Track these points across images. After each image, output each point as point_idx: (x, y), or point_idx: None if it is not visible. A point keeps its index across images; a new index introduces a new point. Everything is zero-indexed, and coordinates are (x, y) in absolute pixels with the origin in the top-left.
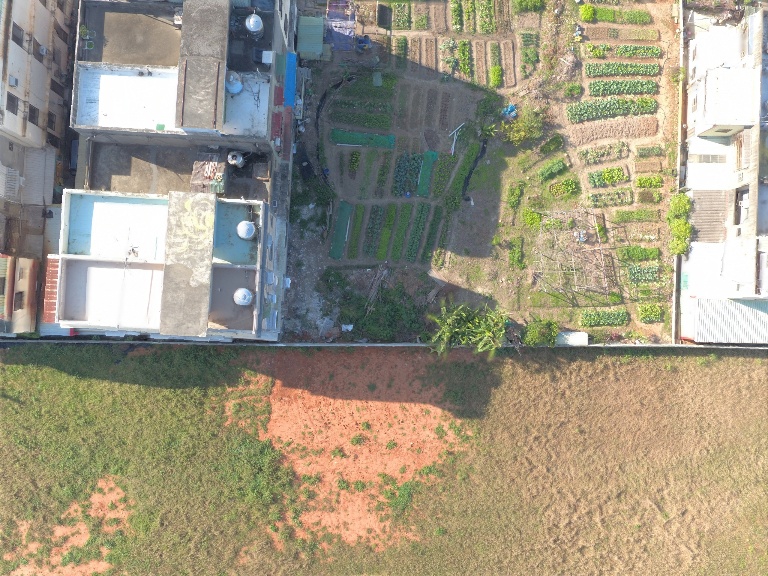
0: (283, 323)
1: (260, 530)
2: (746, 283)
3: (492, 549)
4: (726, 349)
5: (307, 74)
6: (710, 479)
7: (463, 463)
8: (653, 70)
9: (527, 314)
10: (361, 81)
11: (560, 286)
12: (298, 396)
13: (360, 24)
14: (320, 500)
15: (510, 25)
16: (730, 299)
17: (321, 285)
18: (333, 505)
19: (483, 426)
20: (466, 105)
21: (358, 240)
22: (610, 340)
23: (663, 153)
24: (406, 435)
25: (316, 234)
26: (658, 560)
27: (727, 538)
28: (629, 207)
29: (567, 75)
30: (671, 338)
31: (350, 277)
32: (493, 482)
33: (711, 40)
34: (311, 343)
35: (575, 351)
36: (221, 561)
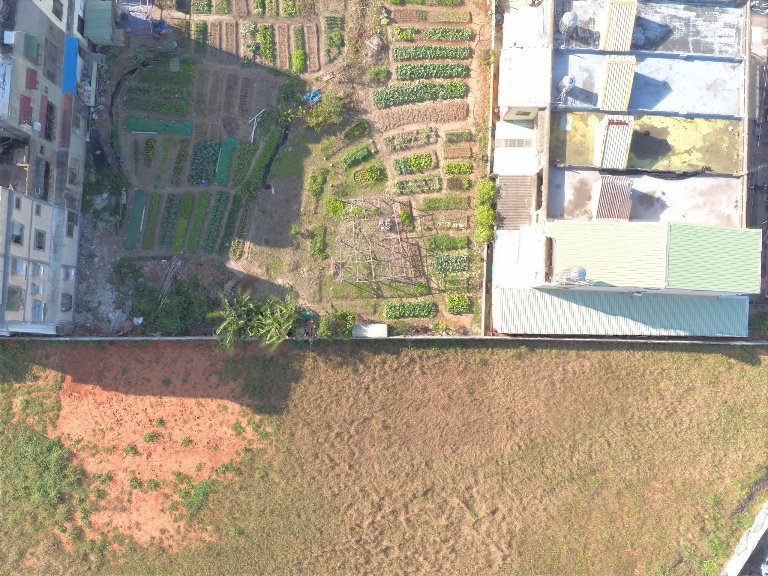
0: (74, 316)
1: (47, 531)
2: (539, 271)
3: (291, 550)
4: (539, 341)
5: (101, 60)
6: (522, 476)
7: (261, 460)
8: (463, 53)
9: (329, 306)
10: (157, 67)
11: (363, 276)
12: (89, 392)
13: (158, 8)
14: (111, 499)
15: (314, 8)
16: (534, 288)
17: (114, 277)
18: (125, 505)
19: (282, 422)
20: (267, 90)
21: (153, 230)
22: (415, 332)
23: (474, 138)
24: (202, 432)
25: (110, 224)
26: (467, 561)
27: (540, 538)
28: (437, 194)
29: (372, 59)
30: (480, 330)
31: (144, 268)
32: (292, 480)
33: (518, 21)
34: (102, 337)
35: (380, 344)
36: (5, 563)
